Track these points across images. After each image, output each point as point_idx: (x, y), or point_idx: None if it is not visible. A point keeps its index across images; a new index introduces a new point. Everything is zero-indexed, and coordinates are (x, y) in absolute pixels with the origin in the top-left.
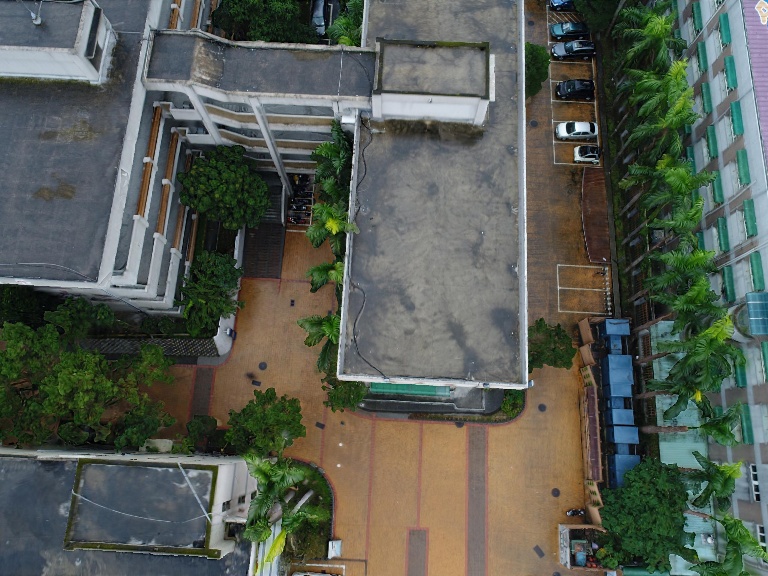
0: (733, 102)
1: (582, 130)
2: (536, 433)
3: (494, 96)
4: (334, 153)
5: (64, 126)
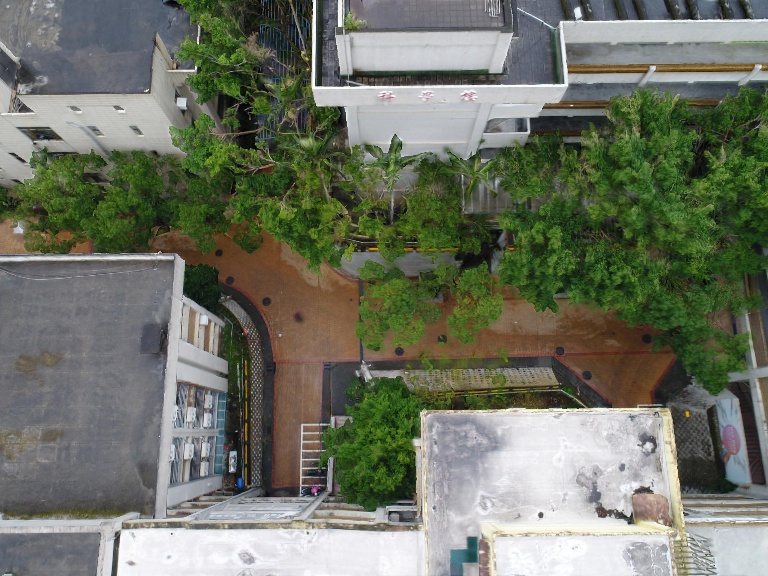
0: None
1: None
2: None
3: None
4: None
5: (33, 450)
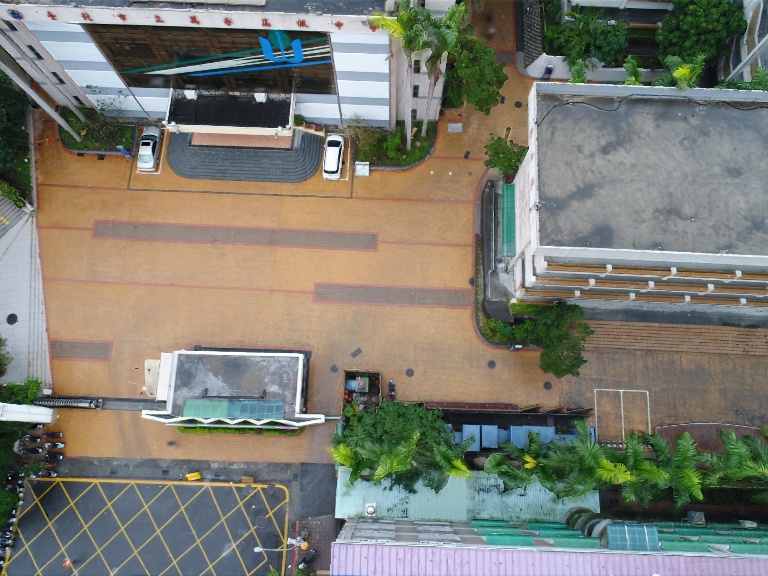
0: None
1: None
2: (467, 356)
3: None
4: (759, 85)
5: None
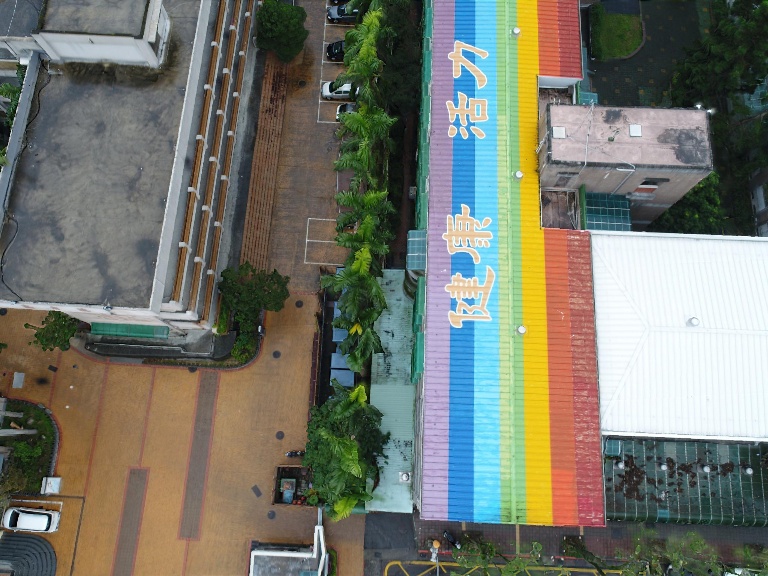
0: (427, 51)
1: (343, 89)
2: (267, 378)
3: (154, 37)
4: None
5: None
